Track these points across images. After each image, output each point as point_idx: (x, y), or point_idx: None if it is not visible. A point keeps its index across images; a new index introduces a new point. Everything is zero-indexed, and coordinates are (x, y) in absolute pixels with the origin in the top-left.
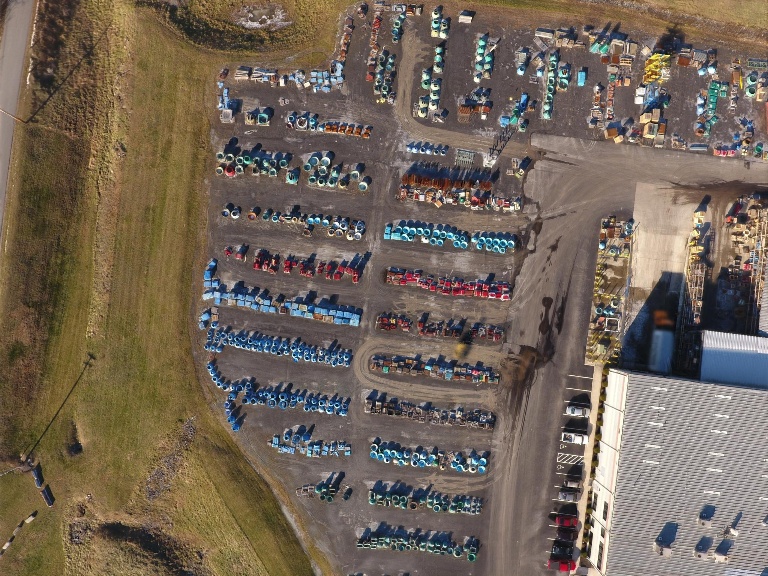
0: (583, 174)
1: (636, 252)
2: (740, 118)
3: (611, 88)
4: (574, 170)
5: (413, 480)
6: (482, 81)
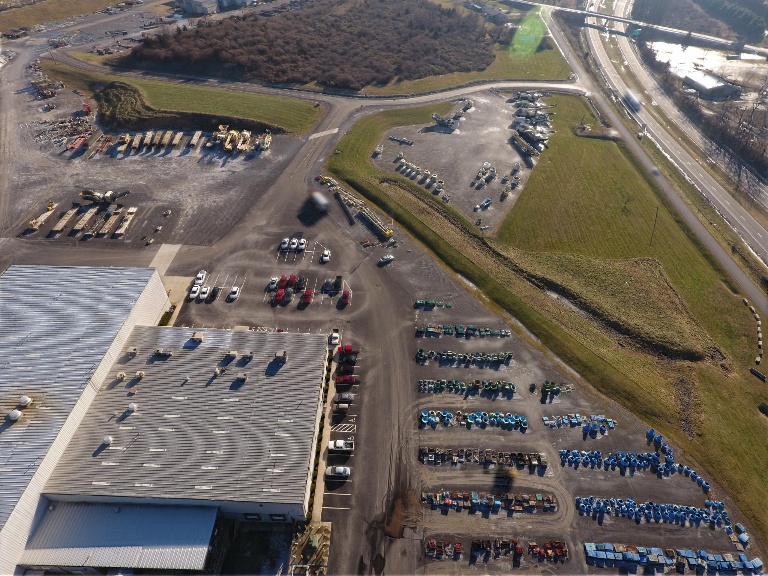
0: None
1: None
2: None
3: None
4: None
5: (482, 402)
6: None
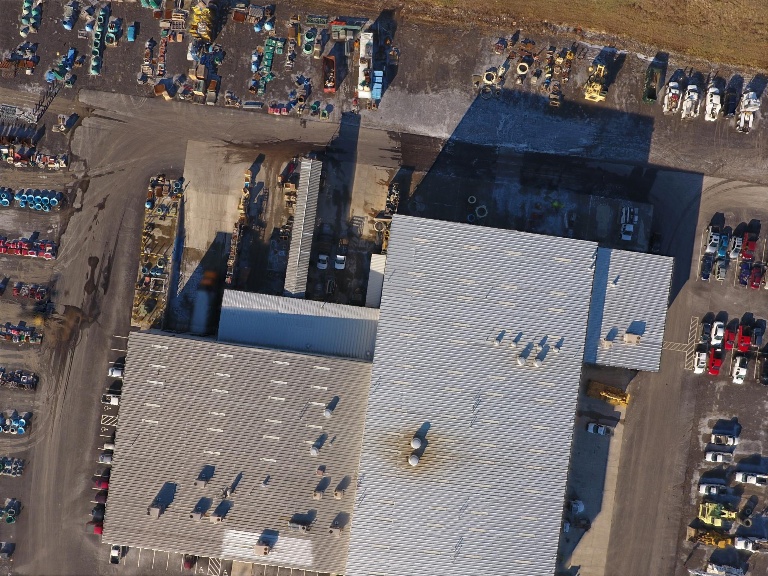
0: (132, 131)
1: (188, 212)
2: (297, 76)
3: (163, 44)
4: (123, 127)
5: None
6: (29, 35)
